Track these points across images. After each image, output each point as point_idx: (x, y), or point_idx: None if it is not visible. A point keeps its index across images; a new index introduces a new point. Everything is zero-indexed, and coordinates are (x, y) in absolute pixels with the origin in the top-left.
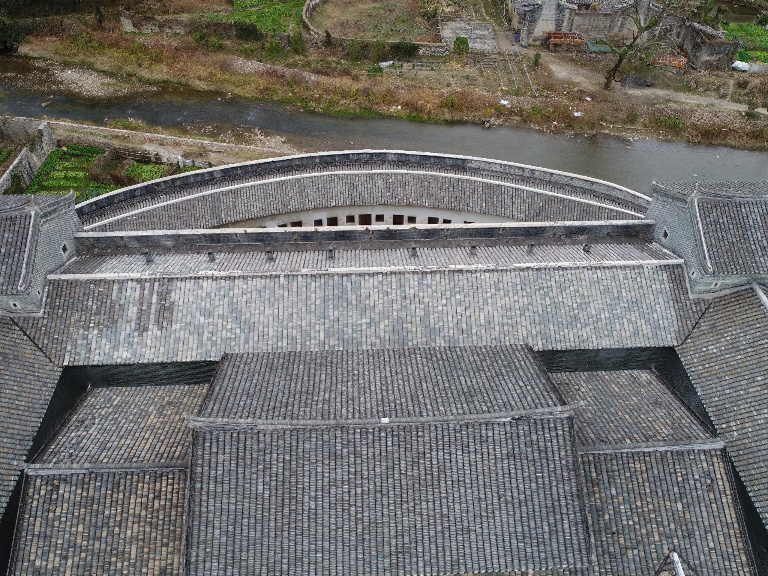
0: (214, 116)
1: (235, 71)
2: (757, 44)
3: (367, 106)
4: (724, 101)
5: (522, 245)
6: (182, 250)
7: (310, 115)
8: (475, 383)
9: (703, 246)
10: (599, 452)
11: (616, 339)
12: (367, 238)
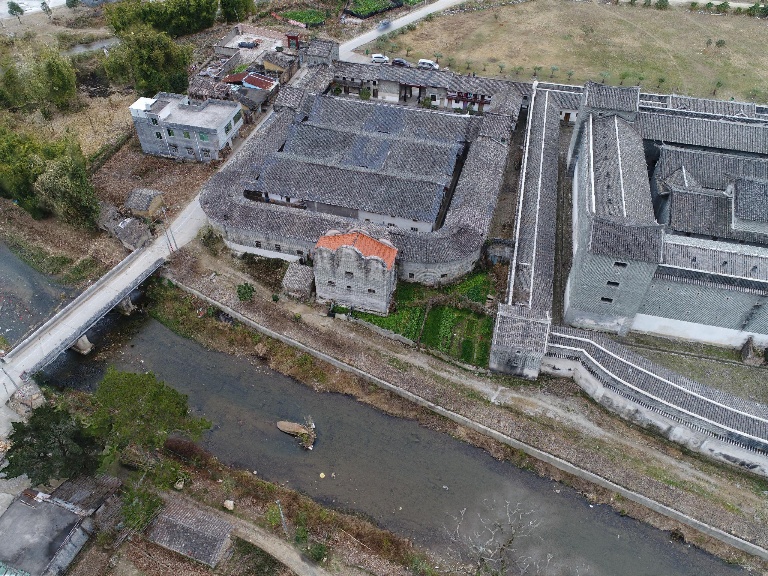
0: None
1: None
2: None
3: None
4: None
5: None
6: None
7: None
8: (762, 199)
9: None
10: None
11: None
12: None
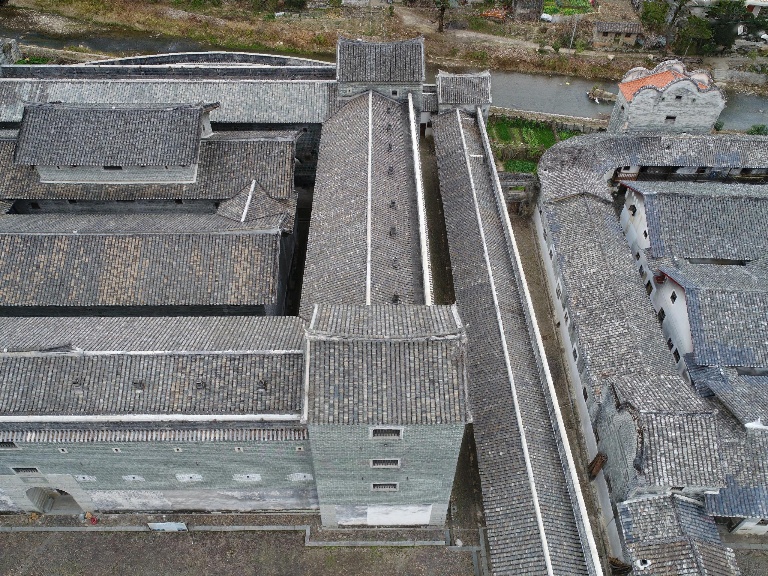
0: (144, 47)
1: (166, 17)
2: (571, 4)
3: (258, 42)
4: (527, 42)
5: (262, 79)
6: (63, 77)
7: (215, 48)
8: None
9: (337, 66)
10: (231, 141)
11: (289, 118)
12: (172, 74)
